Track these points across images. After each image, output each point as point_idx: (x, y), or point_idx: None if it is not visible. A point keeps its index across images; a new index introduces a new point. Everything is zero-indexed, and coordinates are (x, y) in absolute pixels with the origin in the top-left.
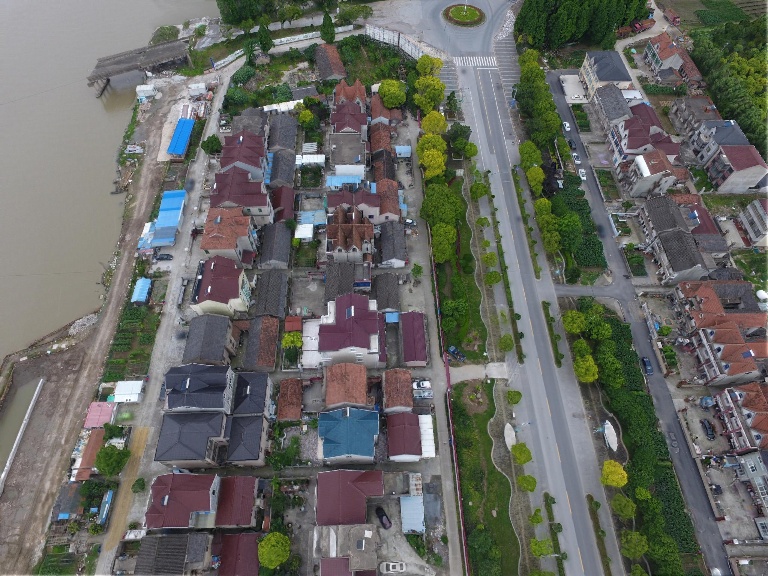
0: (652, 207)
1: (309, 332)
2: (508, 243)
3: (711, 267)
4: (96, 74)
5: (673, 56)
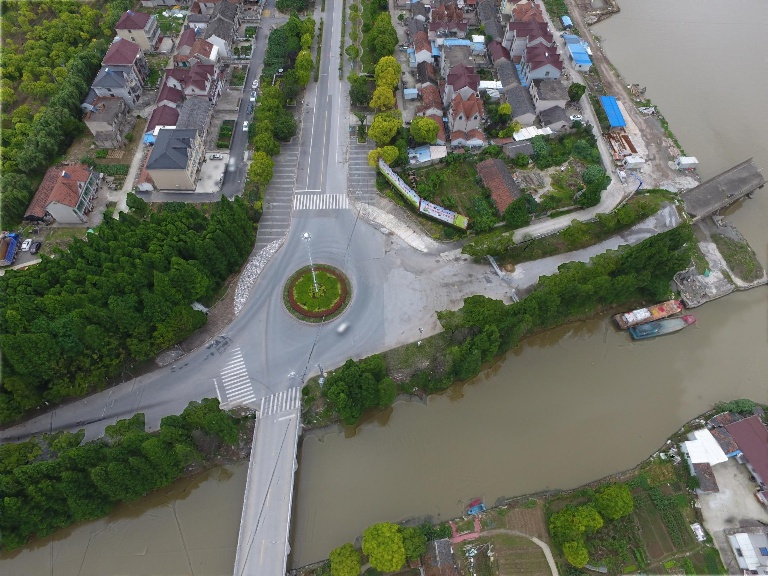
0: (225, 35)
1: (461, 6)
2: (336, 38)
3: (211, 8)
4: (748, 159)
5: (76, 168)
